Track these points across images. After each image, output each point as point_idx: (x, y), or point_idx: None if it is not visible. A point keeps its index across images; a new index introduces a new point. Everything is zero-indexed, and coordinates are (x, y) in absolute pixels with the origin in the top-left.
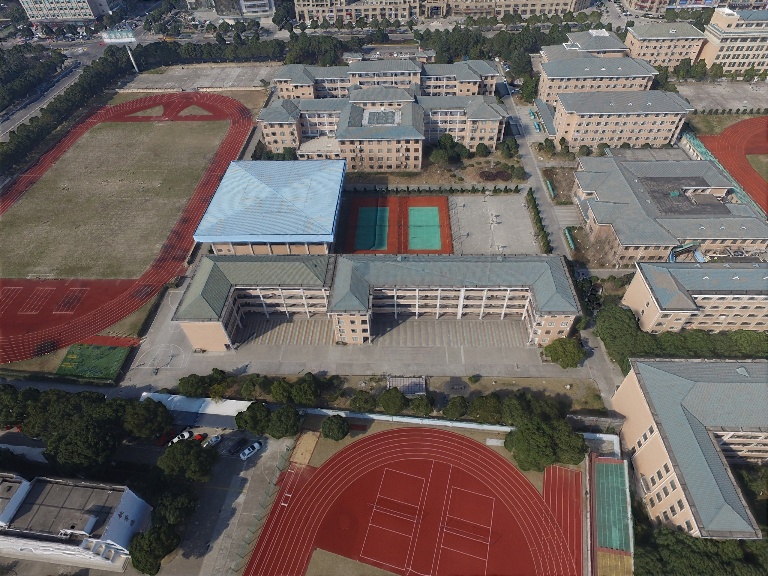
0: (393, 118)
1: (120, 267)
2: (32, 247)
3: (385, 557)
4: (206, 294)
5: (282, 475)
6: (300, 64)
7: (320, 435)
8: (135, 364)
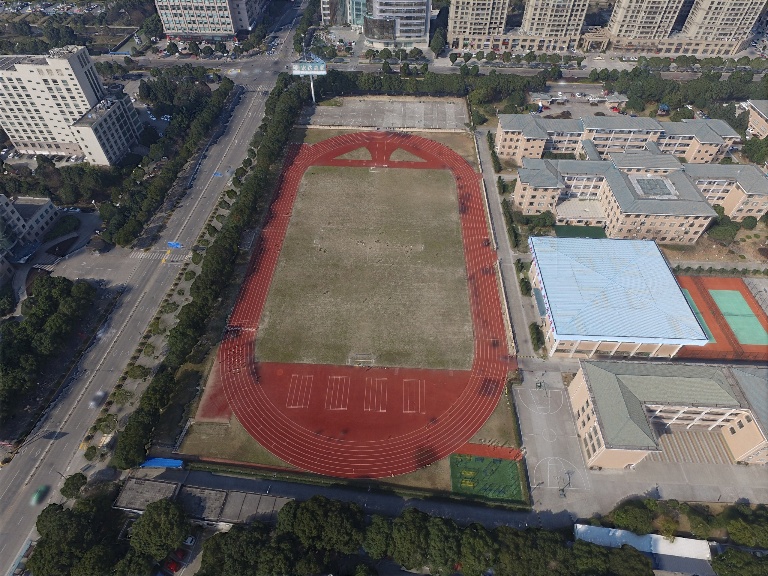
0: (667, 188)
1: (442, 354)
2: (330, 324)
3: None
4: (633, 417)
5: None
6: (529, 115)
7: None
8: (533, 482)
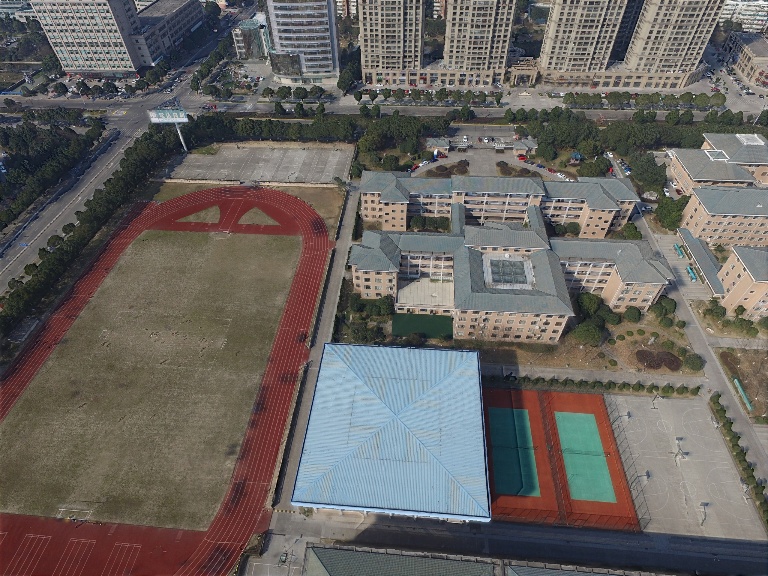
0: (524, 273)
1: (181, 504)
2: (64, 454)
3: None
4: None
5: None
6: (391, 173)
7: None
8: None
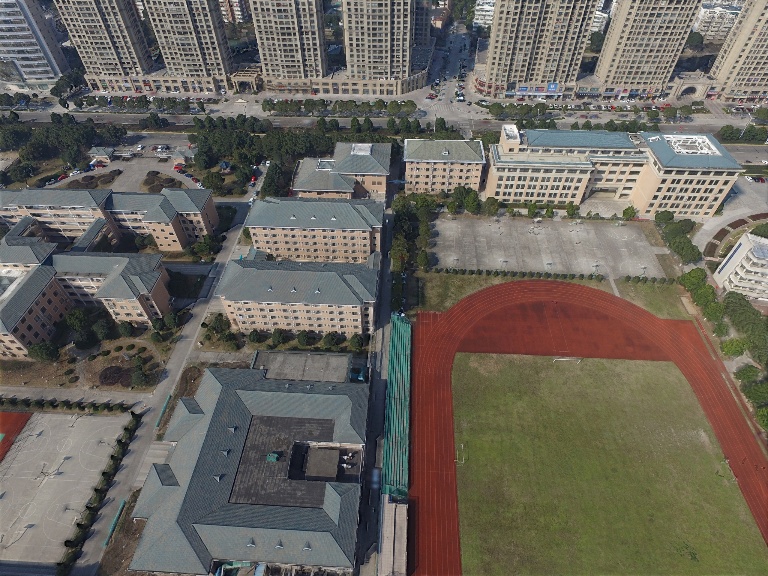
0: (3, 290)
1: None
2: None
3: None
4: None
5: None
6: None
7: None
8: None
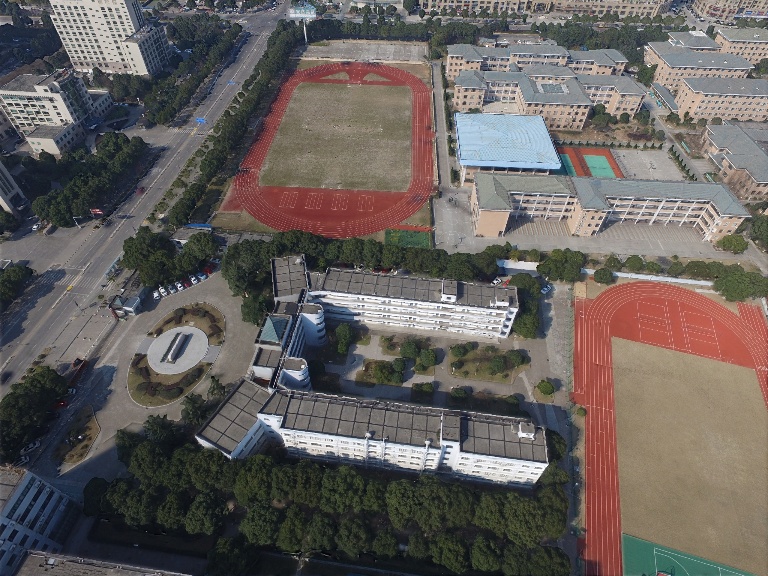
0: (562, 89)
1: (388, 184)
2: (311, 168)
3: (656, 341)
4: (498, 193)
5: (573, 302)
6: (469, 44)
7: (586, 283)
8: (438, 242)
